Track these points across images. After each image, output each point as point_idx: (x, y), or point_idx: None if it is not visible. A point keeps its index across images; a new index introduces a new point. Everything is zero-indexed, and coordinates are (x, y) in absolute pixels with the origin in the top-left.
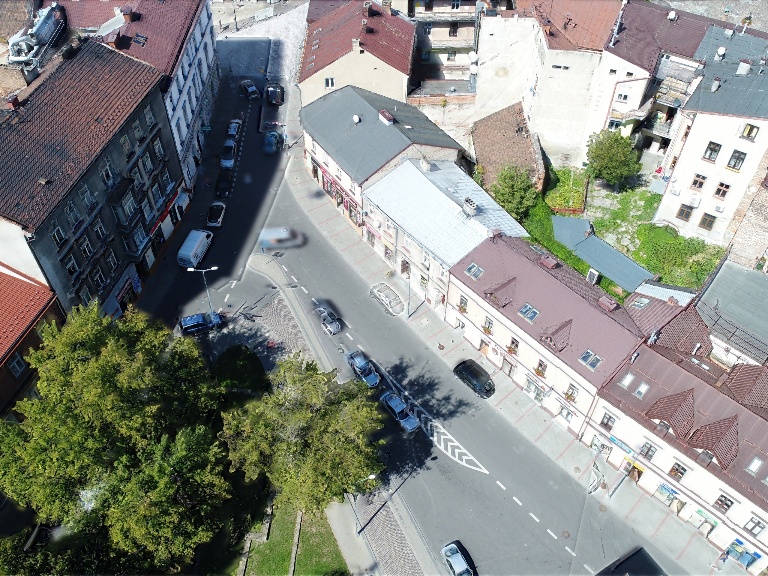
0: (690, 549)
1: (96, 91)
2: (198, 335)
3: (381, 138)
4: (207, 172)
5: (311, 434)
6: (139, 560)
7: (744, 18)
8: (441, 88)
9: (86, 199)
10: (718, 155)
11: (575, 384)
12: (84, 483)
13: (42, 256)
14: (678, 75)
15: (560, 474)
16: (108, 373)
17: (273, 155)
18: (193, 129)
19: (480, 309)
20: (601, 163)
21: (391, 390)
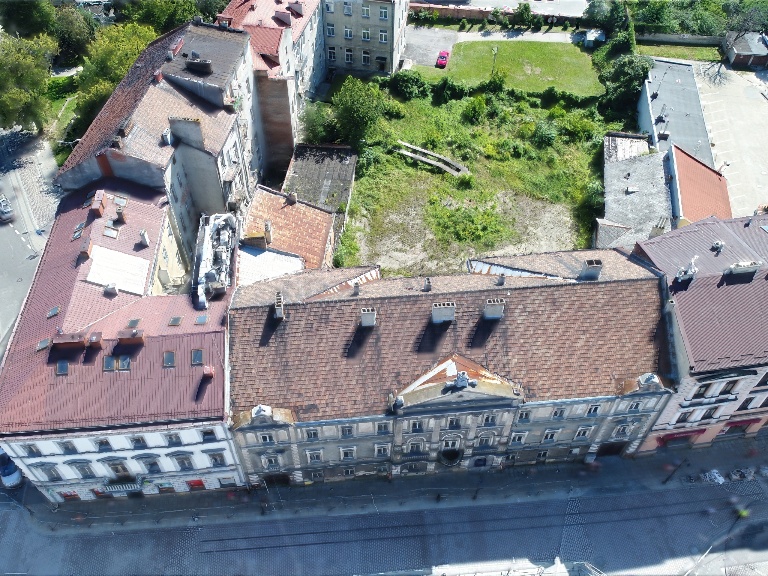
0: None
1: None
2: None
3: None
4: None
5: None
6: None
7: None
8: None
9: None
10: None
11: None
12: None
13: None
14: None
15: None
16: None
17: None
18: None
19: None
20: None
21: None
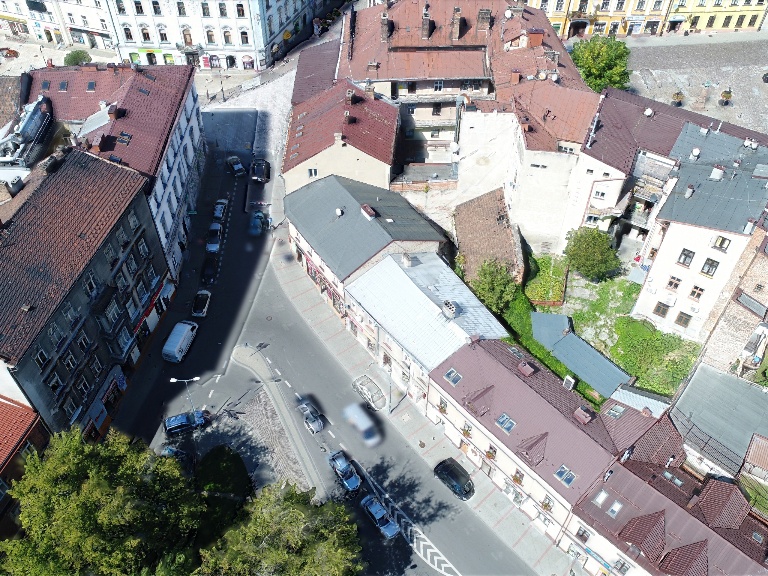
0: None
1: (80, 204)
2: (182, 435)
3: (363, 233)
4: (193, 256)
5: None
6: None
7: (724, 92)
8: (423, 174)
9: (69, 315)
10: (692, 261)
11: (551, 497)
12: None
13: (25, 382)
14: (654, 173)
15: None
16: (89, 510)
17: (258, 237)
18: (179, 217)
19: (459, 413)
20: (579, 261)
21: (372, 492)
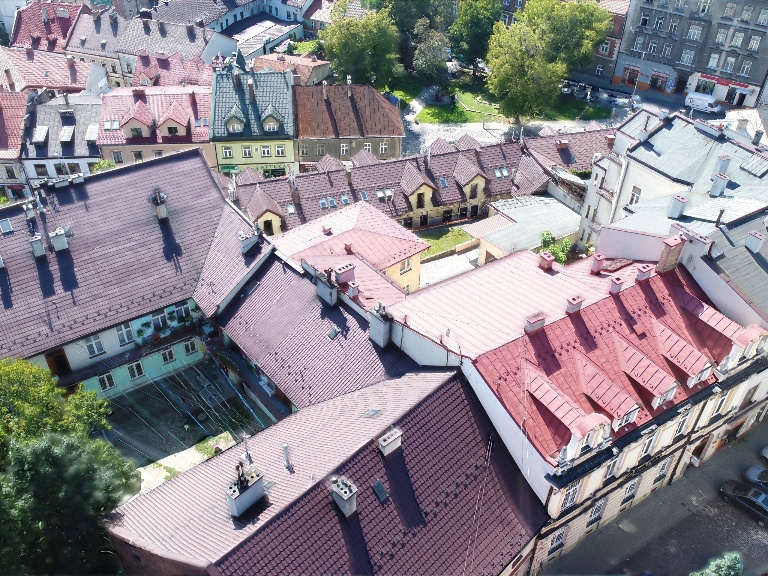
0: None
1: None
2: None
3: None
4: None
5: None
6: None
7: None
8: None
9: (681, 3)
10: None
11: None
12: None
13: None
14: None
15: None
16: None
17: None
18: None
19: None
20: None
21: None
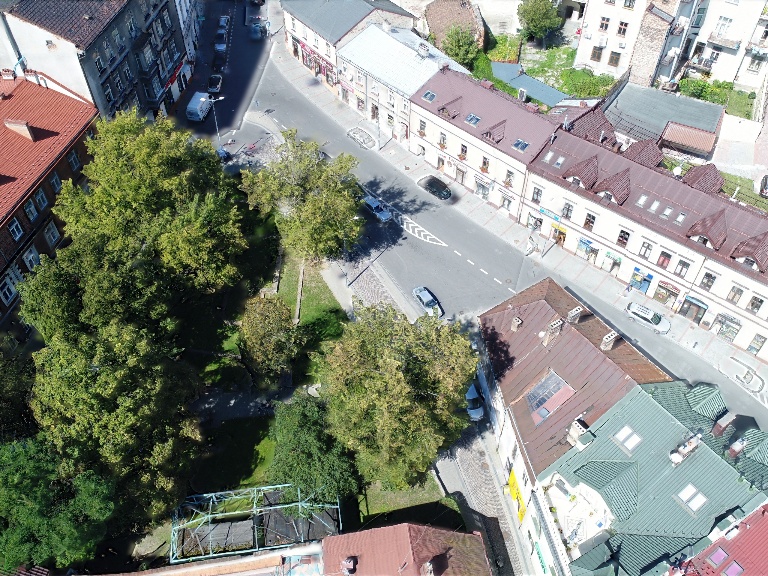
0: (603, 285)
1: None
2: None
3: (349, 8)
4: (204, 55)
5: (309, 184)
6: (184, 280)
7: None
8: None
9: (117, 42)
10: None
11: (511, 169)
12: (138, 226)
13: (89, 75)
14: None
15: (504, 245)
16: (152, 145)
17: (259, 41)
18: (191, 16)
19: (436, 127)
20: (528, 16)
21: None
